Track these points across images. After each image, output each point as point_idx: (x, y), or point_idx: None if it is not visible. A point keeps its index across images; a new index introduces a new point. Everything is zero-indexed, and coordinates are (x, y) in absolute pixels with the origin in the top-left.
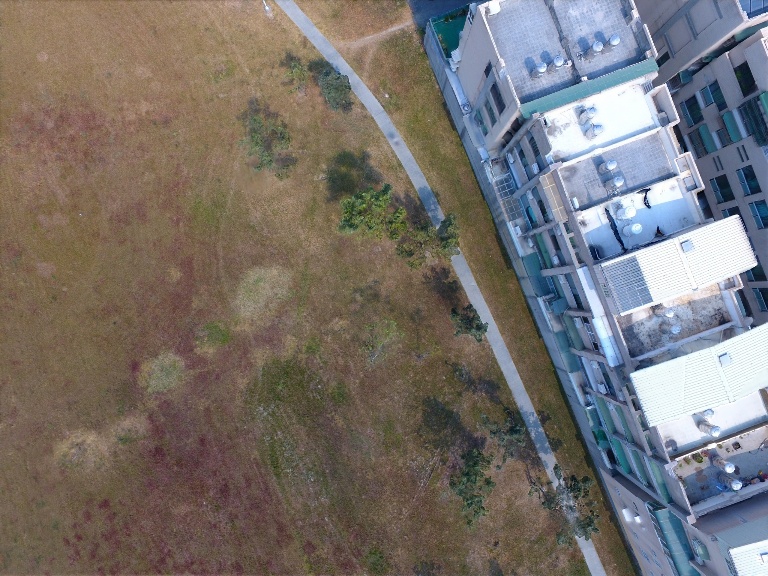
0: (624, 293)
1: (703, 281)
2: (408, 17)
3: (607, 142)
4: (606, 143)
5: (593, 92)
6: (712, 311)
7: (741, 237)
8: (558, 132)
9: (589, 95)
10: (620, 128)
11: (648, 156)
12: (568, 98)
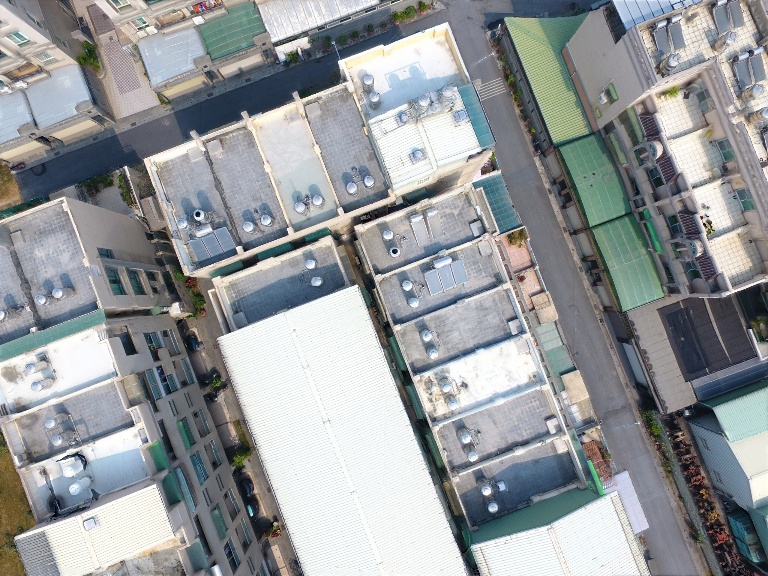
0: (36, 568)
1: (108, 559)
2: (15, 192)
3: (69, 389)
4: (68, 390)
5: (39, 345)
6: (174, 563)
7: (158, 508)
8: (19, 379)
9: (35, 348)
10: (83, 374)
11: (111, 403)
12: (13, 351)
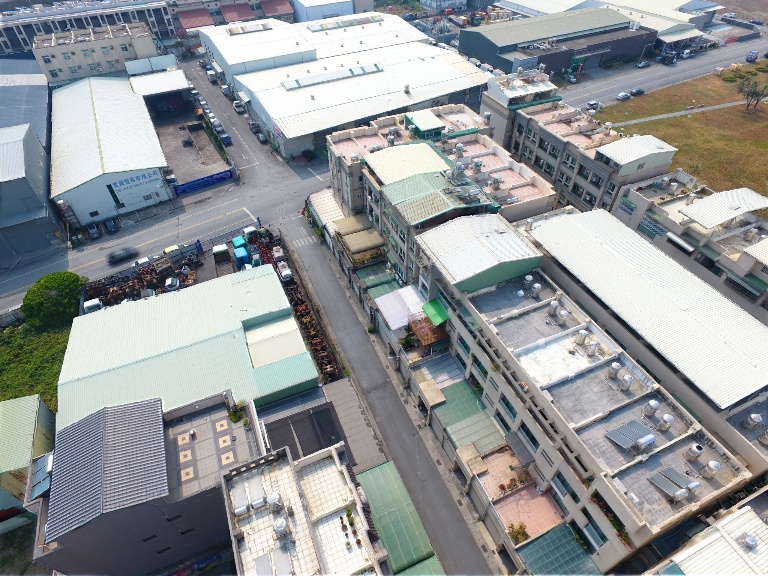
0: None
1: None
2: None
3: None
4: None
5: None
6: None
7: (767, 262)
8: None
9: None
10: None
11: None
12: None
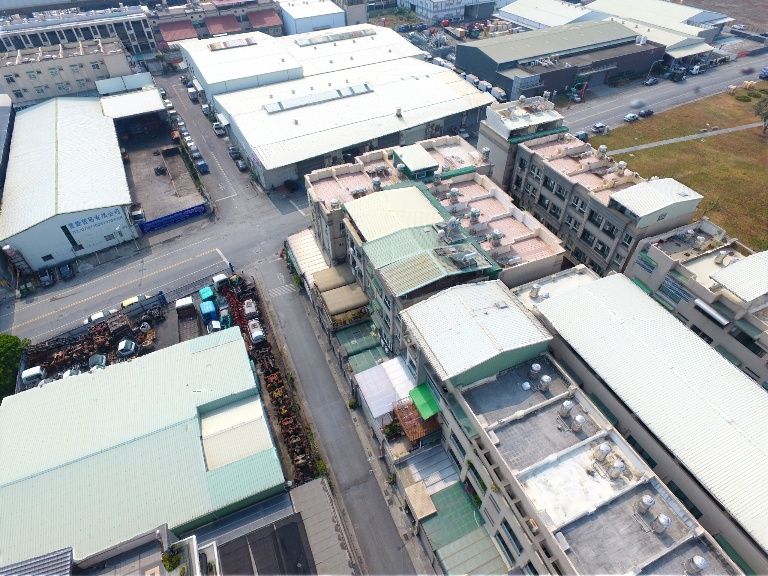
0: None
1: None
2: None
3: None
4: None
5: None
6: None
7: None
8: None
9: None
10: None
11: None
12: None
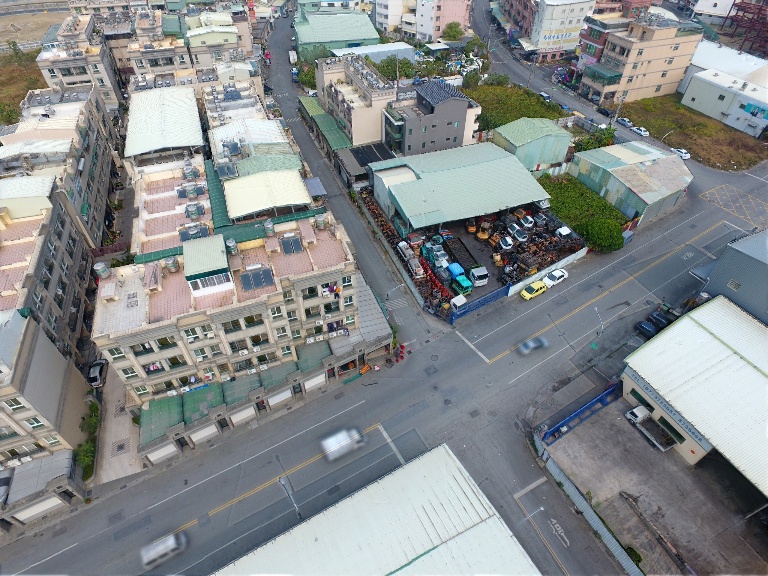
0: (5, 132)
1: None
2: None
3: None
4: None
5: None
6: None
7: None
8: None
9: (54, 104)
10: None
11: None
12: None
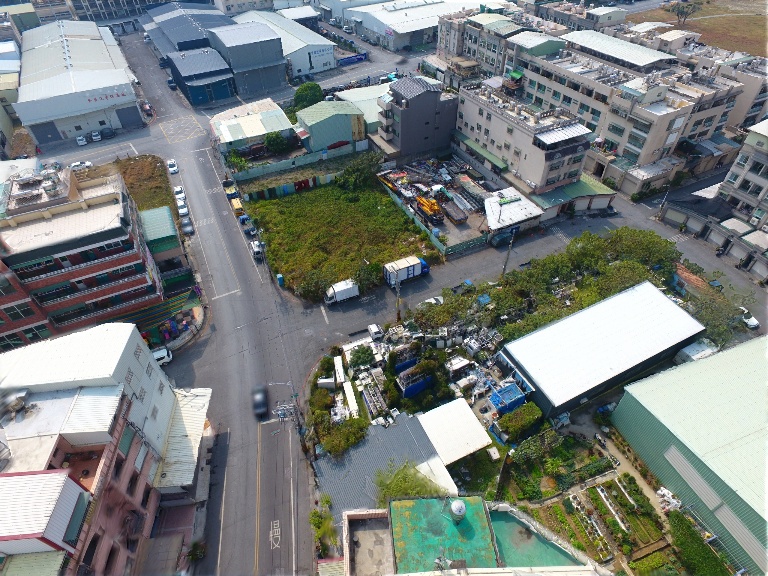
0: None
1: None
2: None
3: None
4: None
5: None
6: None
7: None
8: None
9: None
10: None
11: None
12: None
